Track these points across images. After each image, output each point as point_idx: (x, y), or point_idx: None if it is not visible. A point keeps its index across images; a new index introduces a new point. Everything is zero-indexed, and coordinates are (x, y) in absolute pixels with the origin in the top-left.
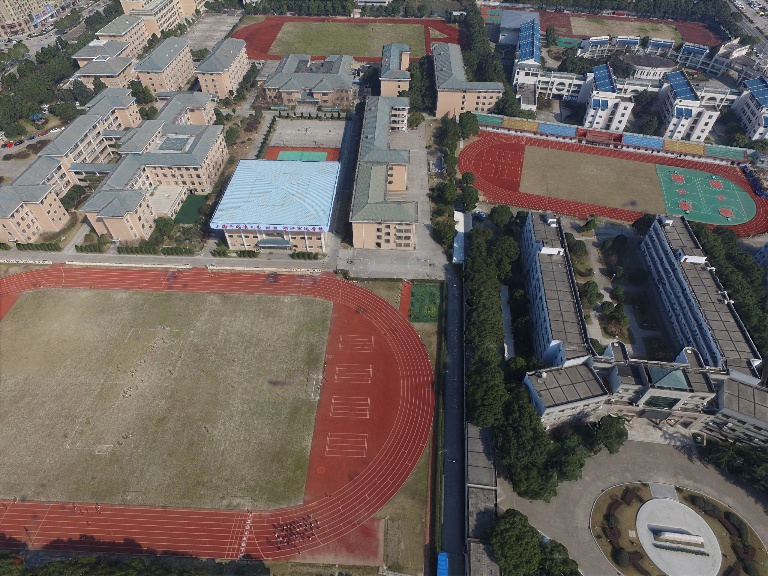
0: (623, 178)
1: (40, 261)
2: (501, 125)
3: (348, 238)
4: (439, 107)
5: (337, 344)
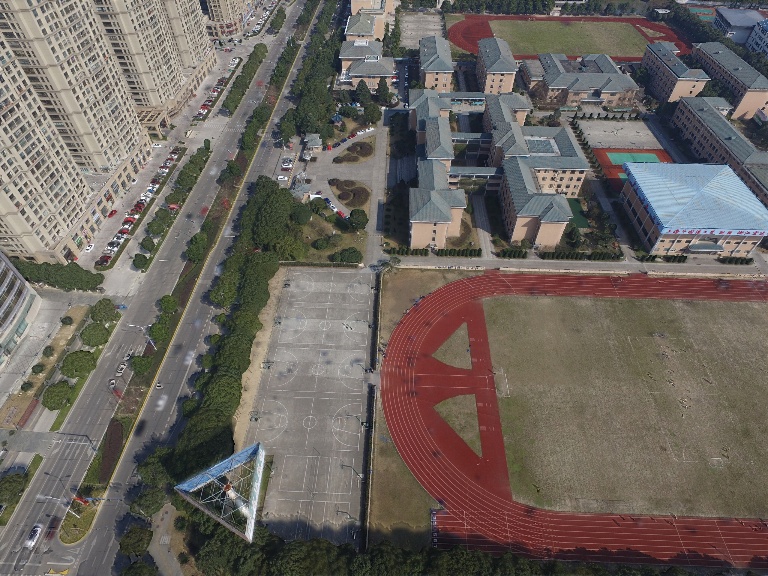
0: None
1: (474, 267)
2: None
3: None
4: (740, 107)
5: None
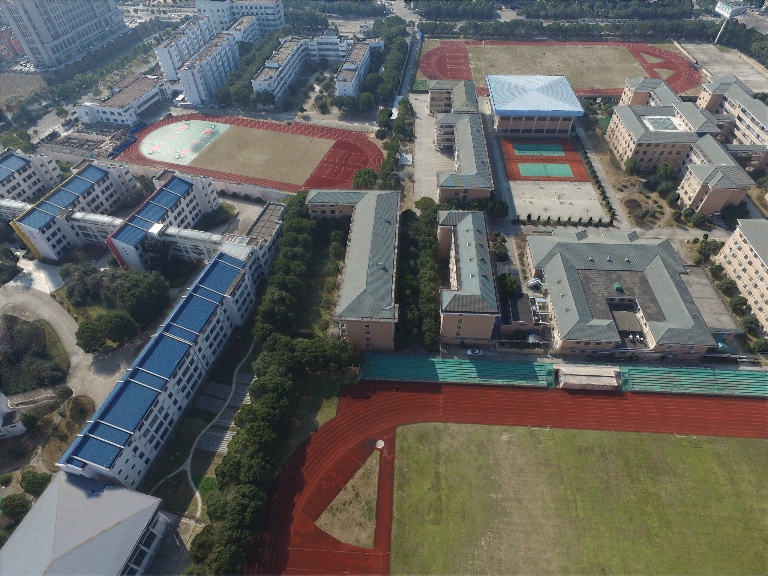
0: (234, 151)
1: None
2: None
3: None
4: None
5: None
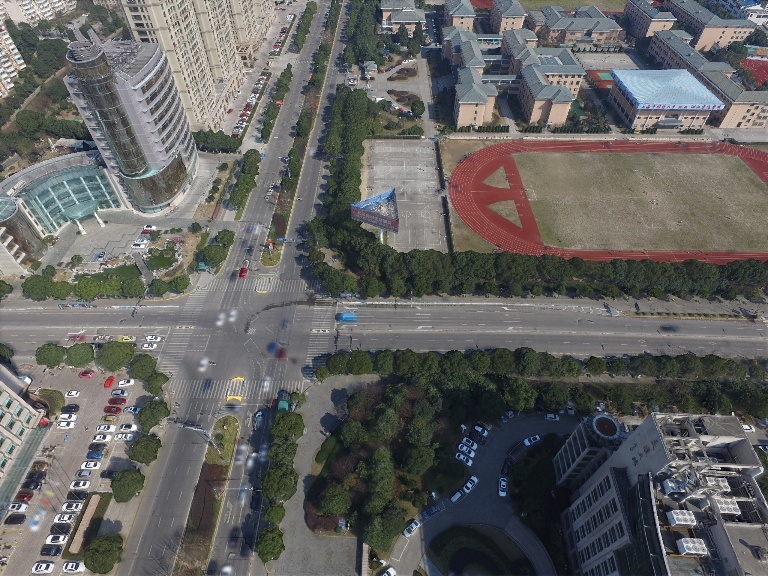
0: None
1: (505, 137)
2: (755, 53)
3: (716, 120)
4: (700, 41)
5: (766, 177)
